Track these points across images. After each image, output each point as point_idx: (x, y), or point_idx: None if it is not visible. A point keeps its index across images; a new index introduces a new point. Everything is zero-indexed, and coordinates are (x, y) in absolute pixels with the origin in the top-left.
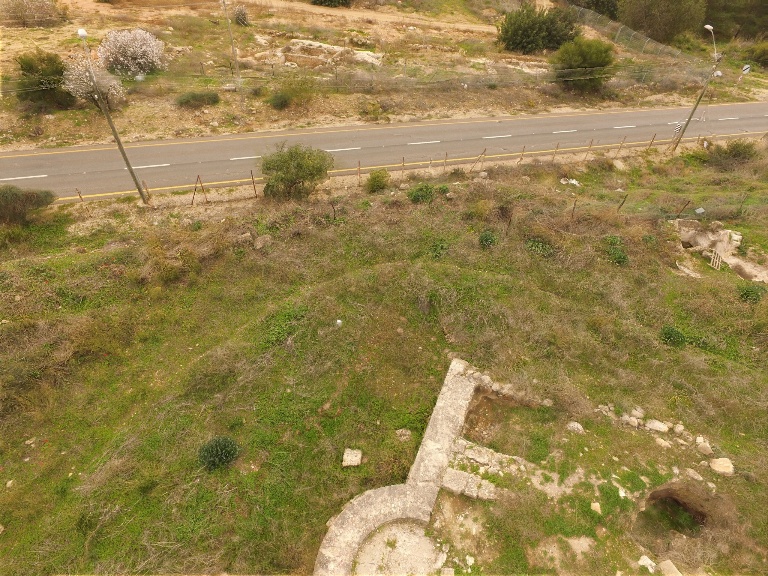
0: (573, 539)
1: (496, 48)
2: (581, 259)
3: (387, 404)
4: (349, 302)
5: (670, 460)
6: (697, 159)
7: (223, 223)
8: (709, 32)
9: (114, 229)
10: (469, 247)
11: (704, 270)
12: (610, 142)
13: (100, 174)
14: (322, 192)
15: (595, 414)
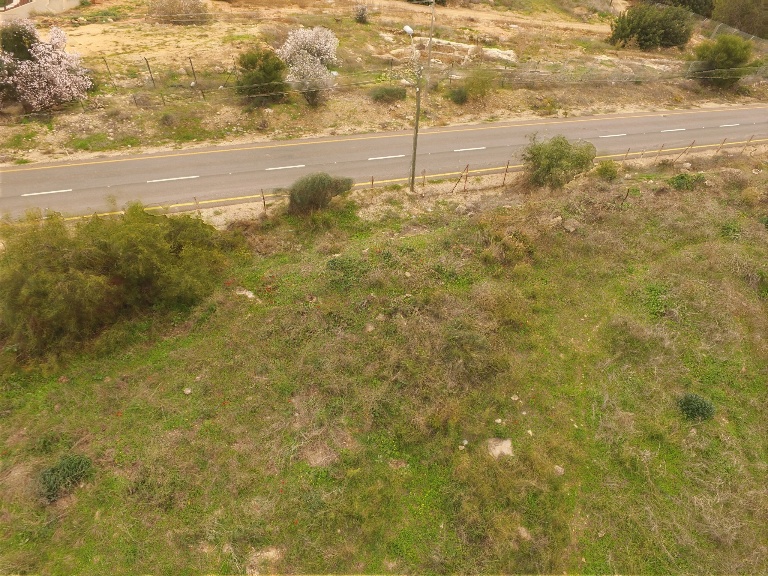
0: None
1: (636, 45)
2: None
3: None
4: (694, 279)
5: None
6: None
7: (529, 208)
8: None
9: (398, 215)
10: None
11: None
12: None
13: (351, 164)
14: None
15: None
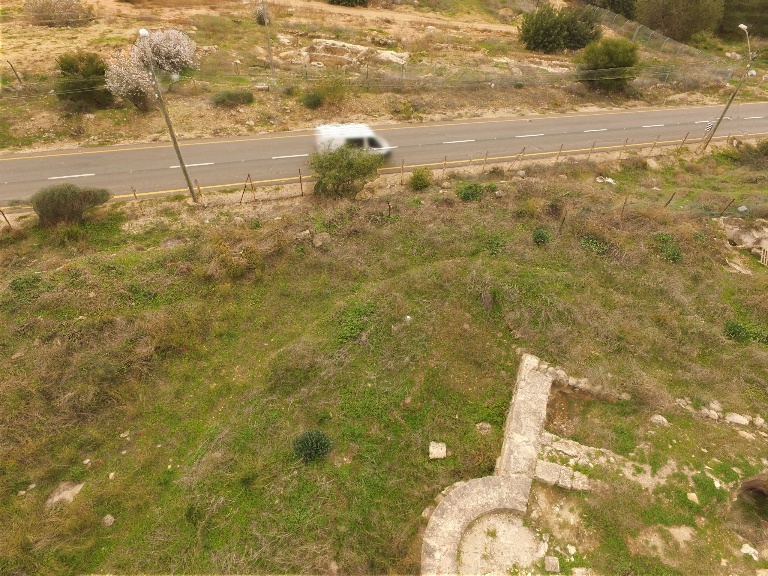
0: (674, 528)
1: (522, 47)
2: (635, 256)
3: (463, 398)
4: (415, 298)
5: (757, 452)
6: (728, 158)
7: (281, 221)
8: (743, 32)
9: (167, 227)
10: (523, 244)
11: (754, 267)
12: (641, 141)
13: (147, 173)
14: (366, 190)
15: (674, 407)
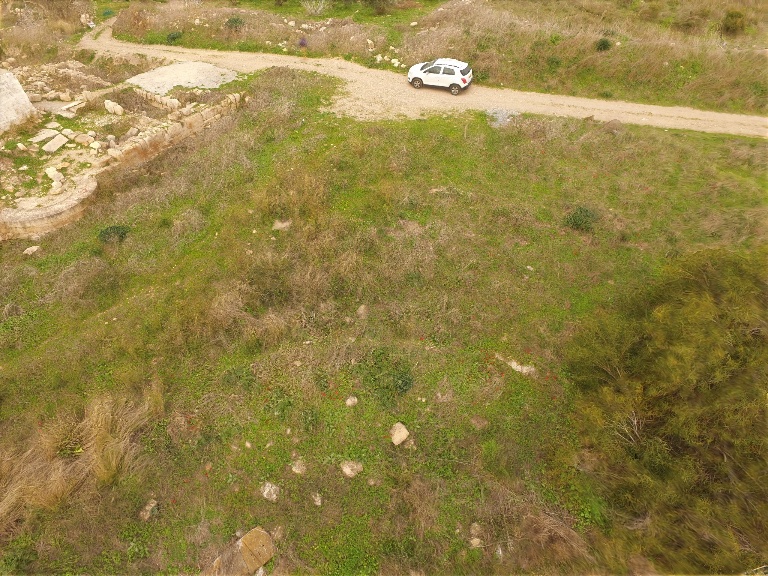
0: None
1: None
2: None
3: None
4: None
5: None
6: None
7: None
8: None
9: None
10: None
11: None
12: None
13: None
14: None
15: None
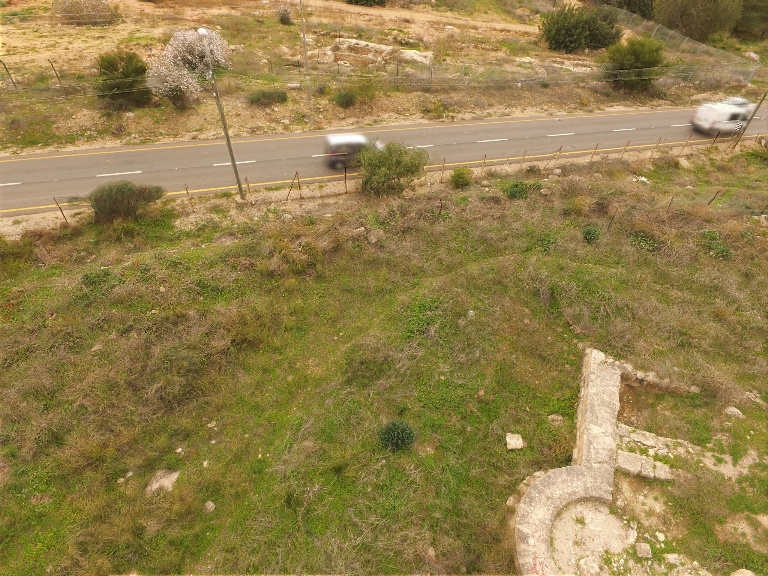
0: (761, 516)
1: (547, 47)
2: (685, 253)
3: (532, 391)
4: (476, 294)
5: None
6: (757, 157)
7: (335, 218)
8: None
9: (218, 224)
10: (574, 241)
11: None
12: (671, 140)
13: (192, 170)
14: (407, 188)
15: (744, 400)
